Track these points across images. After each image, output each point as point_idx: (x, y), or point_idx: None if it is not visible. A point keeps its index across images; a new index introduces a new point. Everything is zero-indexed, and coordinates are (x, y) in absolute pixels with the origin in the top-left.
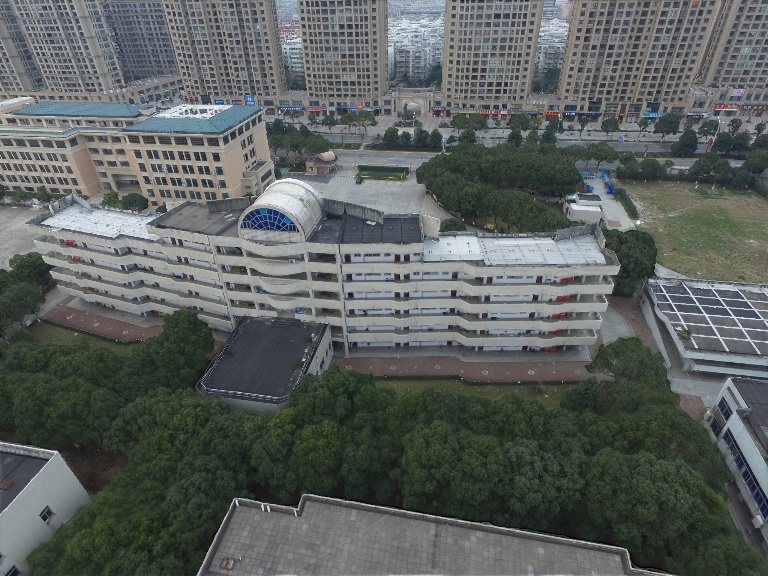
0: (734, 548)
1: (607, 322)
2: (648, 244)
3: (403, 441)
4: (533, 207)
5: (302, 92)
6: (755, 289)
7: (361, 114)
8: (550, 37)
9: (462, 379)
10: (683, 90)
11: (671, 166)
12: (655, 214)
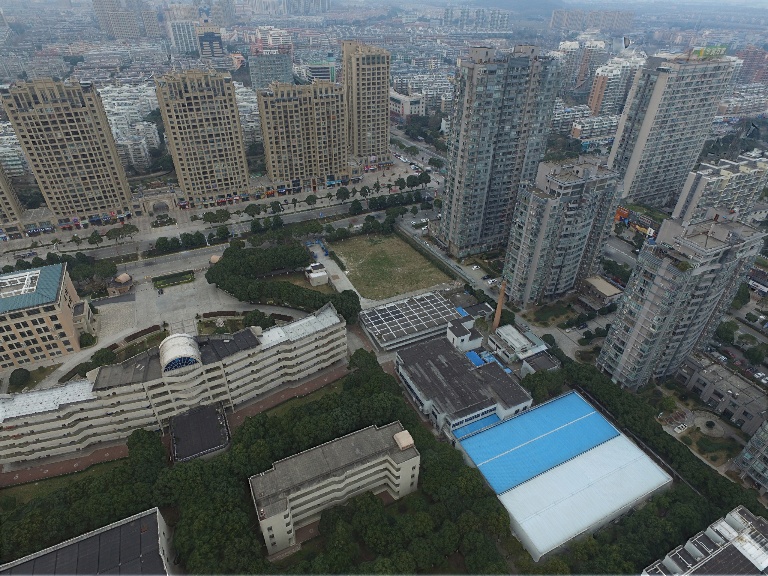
0: (403, 410)
1: (349, 340)
2: (354, 296)
3: (294, 431)
4: (294, 289)
5: (42, 210)
6: (401, 301)
7: (125, 229)
8: (241, 113)
9: (297, 397)
10: (344, 164)
11: (352, 227)
12: (353, 264)
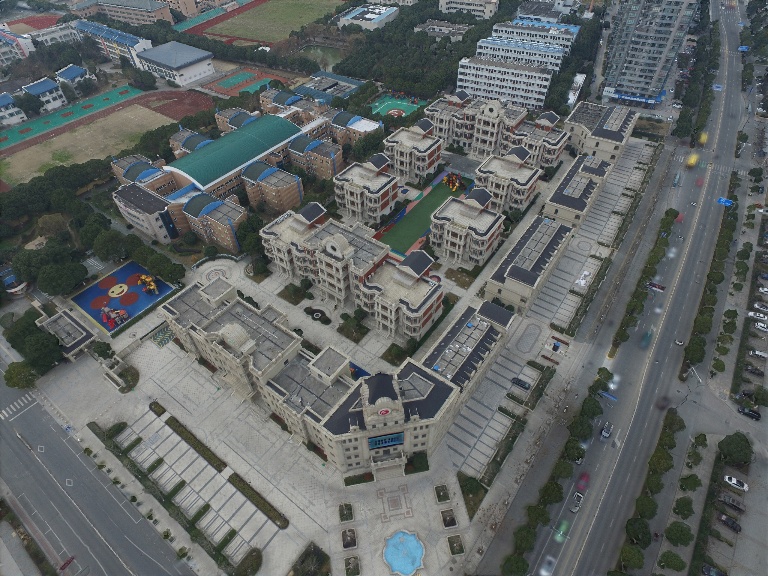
0: (505, 3)
1: None
2: None
3: None
4: None
5: None
6: None
7: None
8: None
9: None
10: None
11: None
12: None
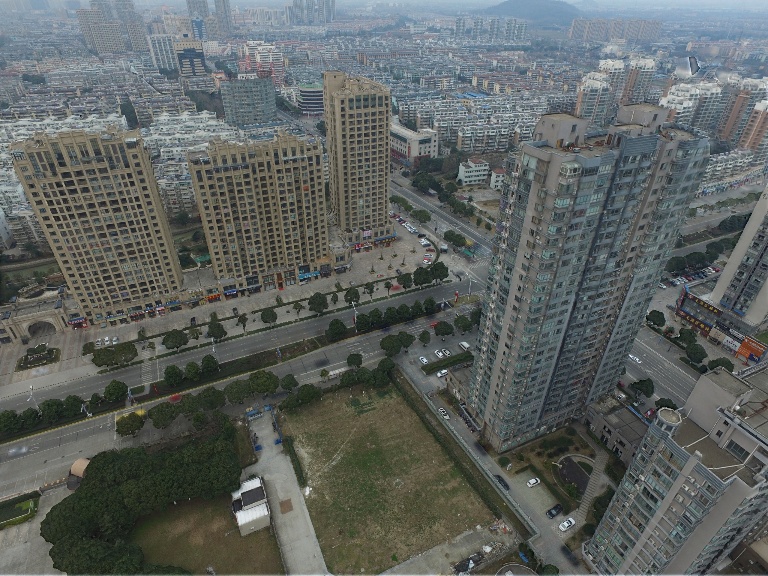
0: None
1: None
2: None
3: None
4: None
5: None
6: None
7: None
8: None
9: None
10: (324, 248)
11: (327, 375)
12: (321, 467)
